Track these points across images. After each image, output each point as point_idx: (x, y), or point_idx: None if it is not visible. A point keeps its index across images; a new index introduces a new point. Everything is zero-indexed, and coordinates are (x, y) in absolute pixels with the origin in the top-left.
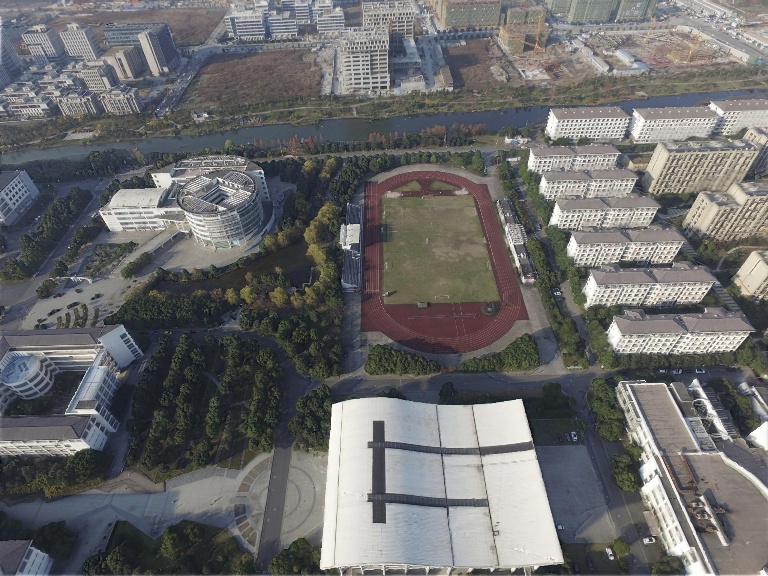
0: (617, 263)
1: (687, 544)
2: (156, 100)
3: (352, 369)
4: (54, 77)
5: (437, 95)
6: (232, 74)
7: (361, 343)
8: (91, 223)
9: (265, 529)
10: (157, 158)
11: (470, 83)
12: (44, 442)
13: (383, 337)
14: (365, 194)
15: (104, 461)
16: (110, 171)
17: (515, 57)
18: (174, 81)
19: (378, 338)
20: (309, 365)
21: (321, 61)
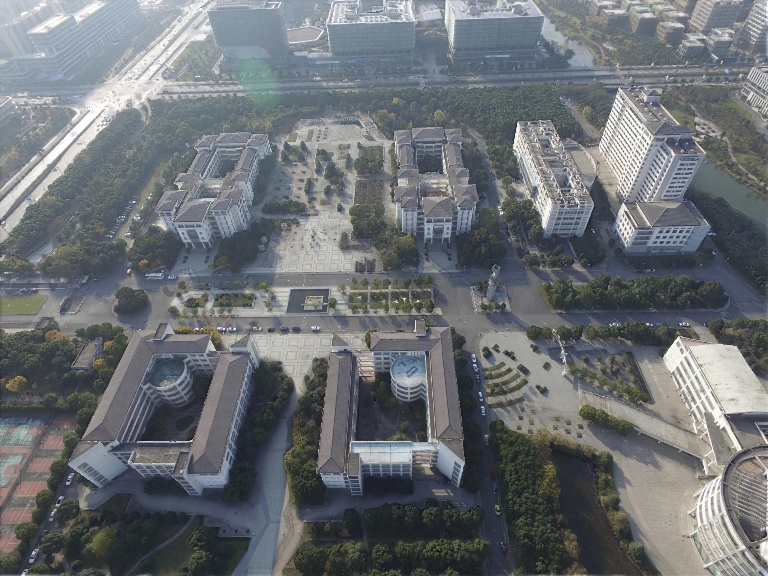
0: None
1: None
2: None
3: None
4: None
5: None
6: None
7: None
8: (664, 330)
9: None
10: None
11: None
12: None
13: None
14: None
15: (310, 500)
16: None
17: None
18: None
19: None
20: None
21: None
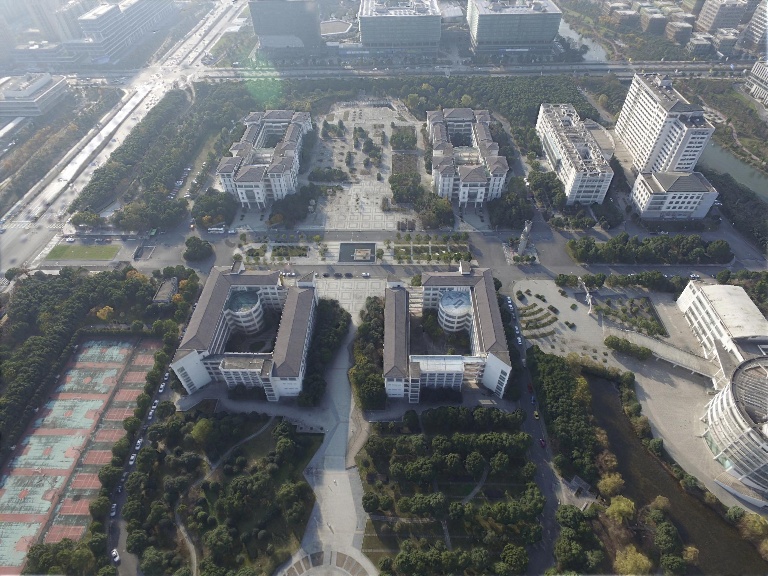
0: None
1: None
2: None
3: None
4: None
5: None
6: None
7: None
8: (677, 279)
9: None
10: None
11: None
12: None
13: None
14: None
15: (375, 403)
16: None
17: None
18: None
19: None
20: None
21: None
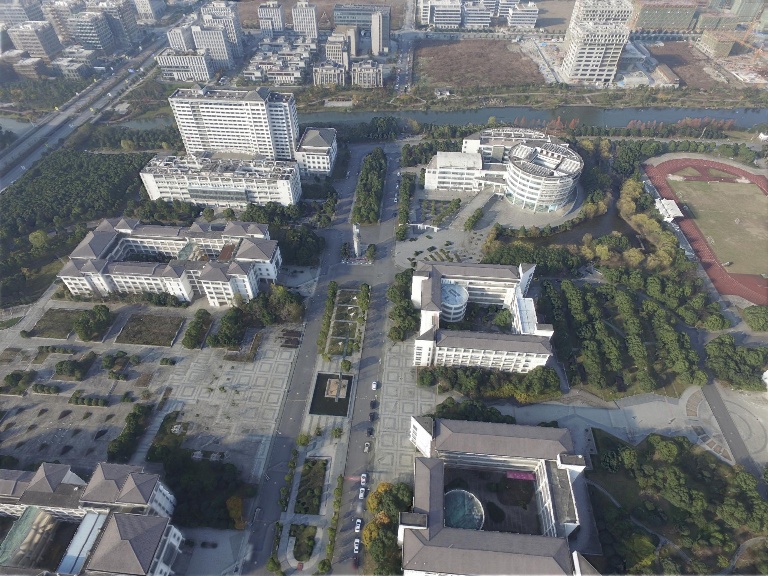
0: None
1: None
2: (391, 77)
3: (731, 325)
4: (291, 49)
5: (665, 91)
6: (449, 58)
7: (726, 304)
8: (407, 180)
9: (733, 448)
10: (426, 128)
11: (691, 82)
12: (512, 355)
13: (744, 301)
14: (648, 175)
15: None
16: (393, 136)
17: (721, 61)
18: (396, 61)
19: (740, 301)
20: (697, 317)
21: (527, 52)
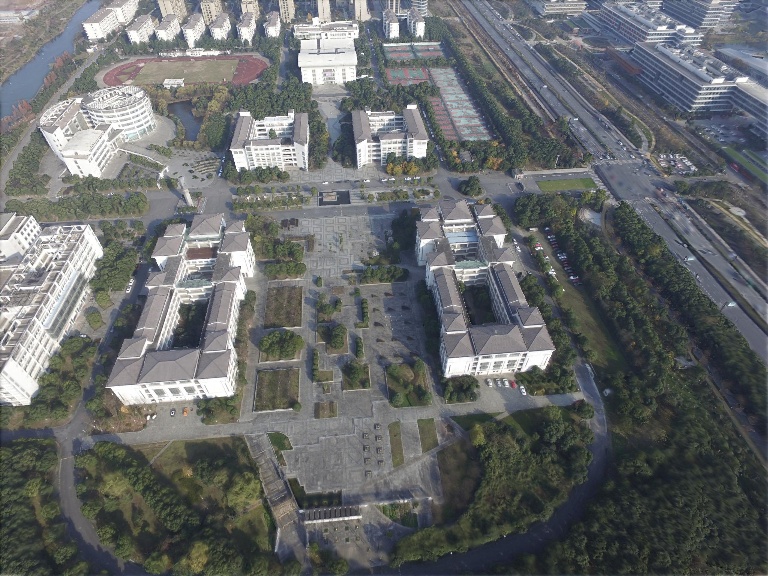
0: (231, 31)
1: (347, 32)
2: None
3: None
4: None
5: None
6: None
7: None
8: (82, 185)
9: None
10: None
11: None
12: None
13: (254, 81)
14: None
15: None
16: None
17: None
18: None
19: None
20: None
21: None
